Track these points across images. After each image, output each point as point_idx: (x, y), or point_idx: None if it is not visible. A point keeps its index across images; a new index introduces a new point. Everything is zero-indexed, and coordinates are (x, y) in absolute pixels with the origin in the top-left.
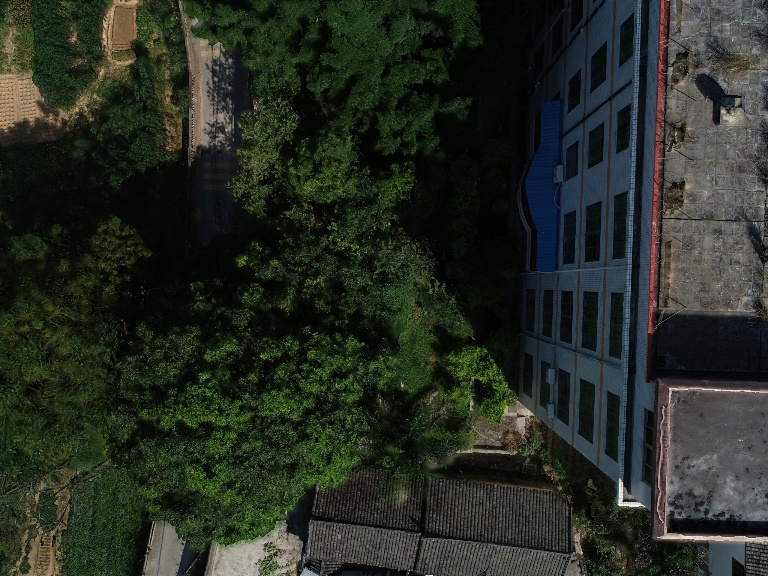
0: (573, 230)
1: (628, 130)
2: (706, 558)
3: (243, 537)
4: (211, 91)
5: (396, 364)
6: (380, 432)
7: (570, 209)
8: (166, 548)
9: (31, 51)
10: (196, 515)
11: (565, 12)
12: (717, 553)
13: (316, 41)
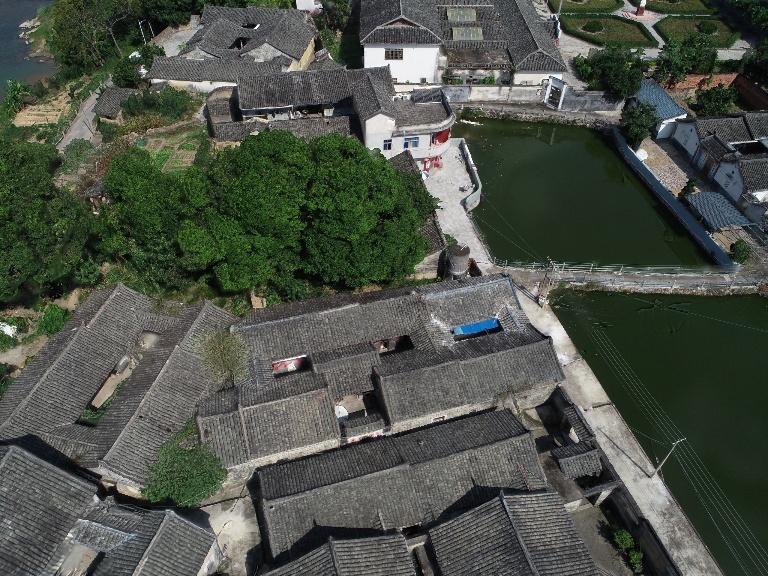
0: None
1: None
2: None
3: None
4: None
5: None
6: None
7: None
8: None
9: None
10: None
11: None
12: None
13: None
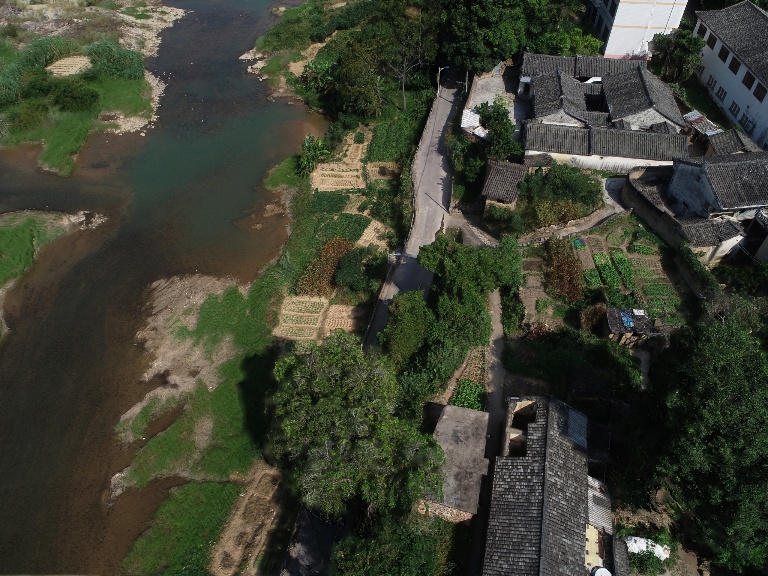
0: None
1: None
2: (713, 80)
3: (503, 27)
4: None
5: None
6: None
7: None
8: (438, 116)
9: None
10: None
11: None
12: (714, 69)
13: None
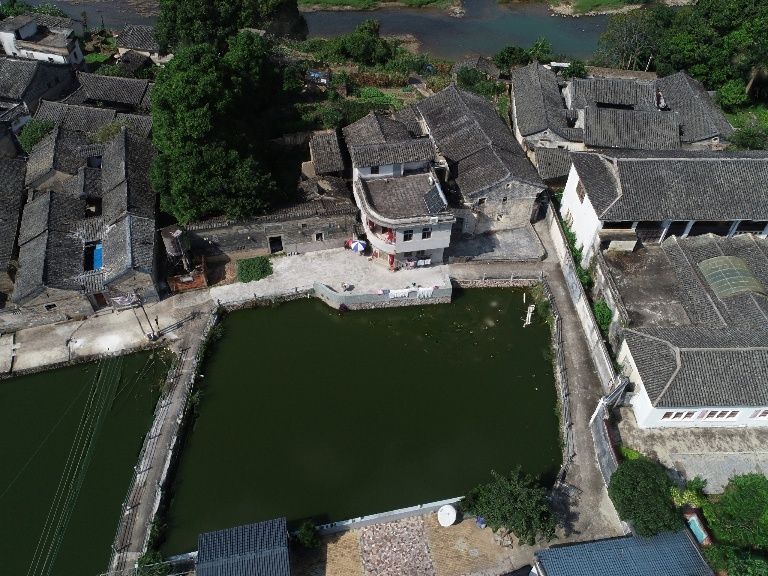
0: None
1: None
2: None
3: None
4: None
5: (759, 111)
6: None
7: None
8: None
9: None
10: (712, 4)
11: None
12: None
13: None
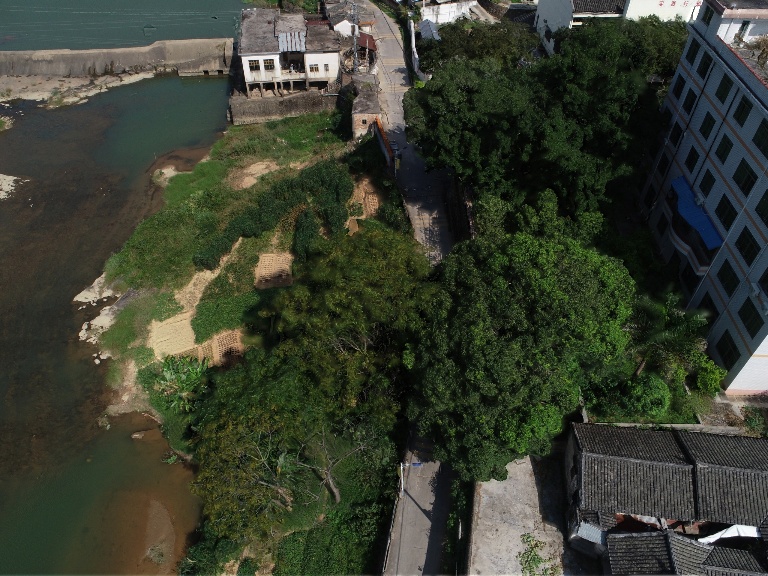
0: (727, 205)
1: (744, 112)
2: None
3: (539, 420)
4: (425, 242)
5: None
6: (643, 312)
7: (719, 200)
8: (402, 575)
9: (289, 242)
10: None
11: (665, 149)
12: None
13: (529, 155)
